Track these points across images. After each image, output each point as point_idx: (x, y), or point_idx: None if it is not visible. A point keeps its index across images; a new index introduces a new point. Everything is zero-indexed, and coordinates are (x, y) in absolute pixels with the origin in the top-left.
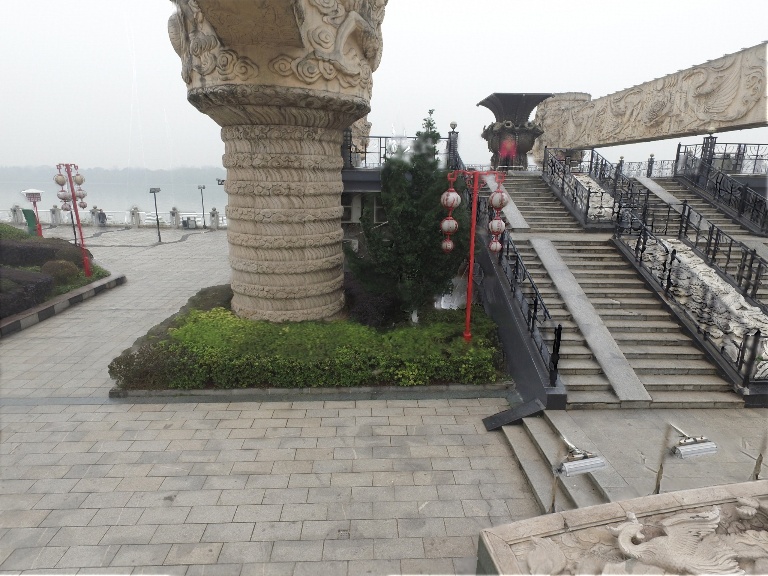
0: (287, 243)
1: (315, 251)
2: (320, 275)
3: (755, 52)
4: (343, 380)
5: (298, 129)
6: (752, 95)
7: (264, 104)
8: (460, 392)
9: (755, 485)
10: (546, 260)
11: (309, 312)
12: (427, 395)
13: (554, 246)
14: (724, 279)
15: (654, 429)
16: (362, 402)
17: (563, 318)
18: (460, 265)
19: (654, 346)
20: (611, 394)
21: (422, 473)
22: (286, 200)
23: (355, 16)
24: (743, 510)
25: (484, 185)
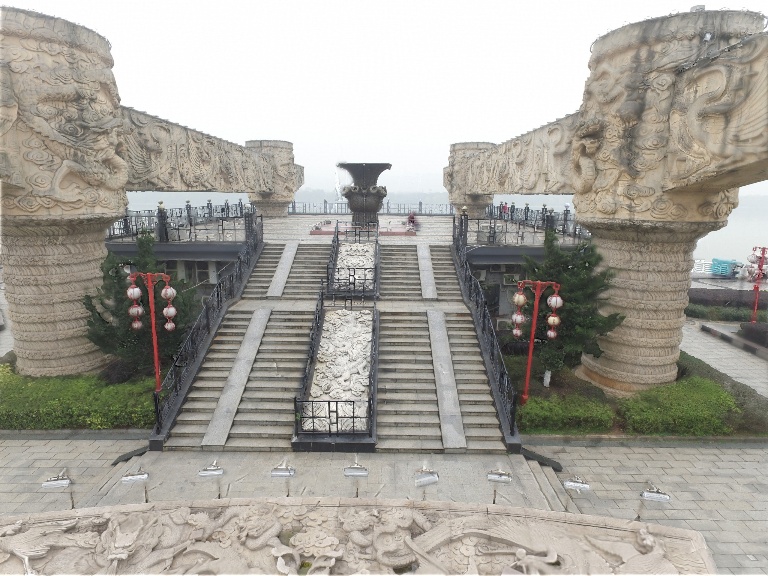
0: (39, 319)
1: (67, 324)
2: (74, 341)
3: (539, 134)
4: (48, 425)
5: (39, 239)
6: (537, 170)
7: (4, 225)
8: (134, 434)
9: (136, 506)
10: (251, 329)
11: (64, 369)
12: (107, 436)
13: (270, 316)
14: (371, 347)
15: (199, 467)
16: (54, 441)
17: (224, 379)
18: (188, 332)
19: (271, 402)
20: (201, 440)
21: (26, 494)
22: (36, 288)
23: (66, 164)
24: (96, 520)
25: (281, 253)
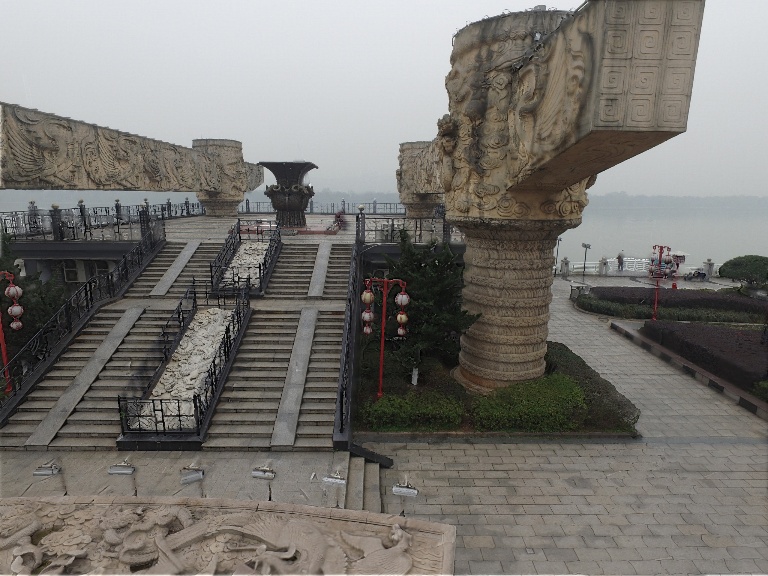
0: None
1: None
2: None
3: None
4: None
5: None
6: None
7: None
8: None
9: None
10: (116, 328)
11: None
12: None
13: (141, 315)
14: None
15: None
16: None
17: (73, 378)
18: None
19: (113, 402)
20: None
21: None
22: None
23: None
24: None
25: None
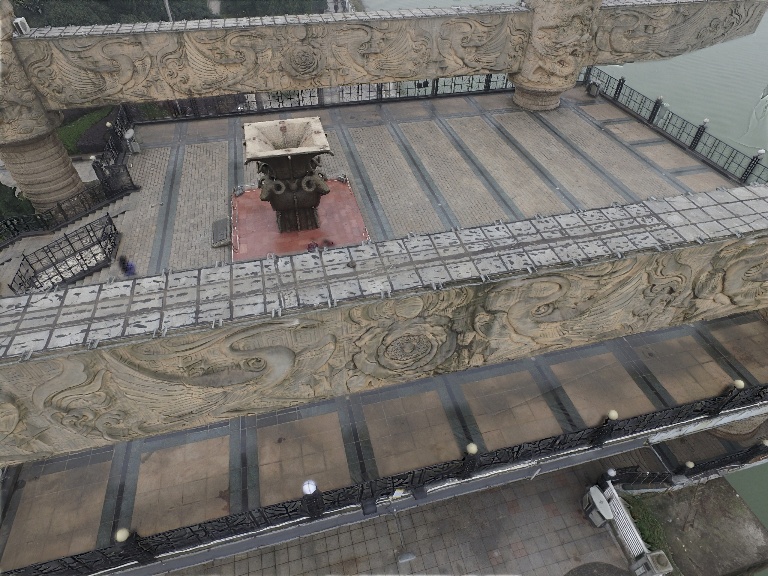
0: None
1: None
2: None
3: None
4: None
5: None
6: None
7: None
8: None
9: None
10: None
11: None
12: None
13: (5, 262)
14: None
15: None
16: None
17: None
18: None
19: None
20: None
21: None
22: None
23: None
24: None
25: None
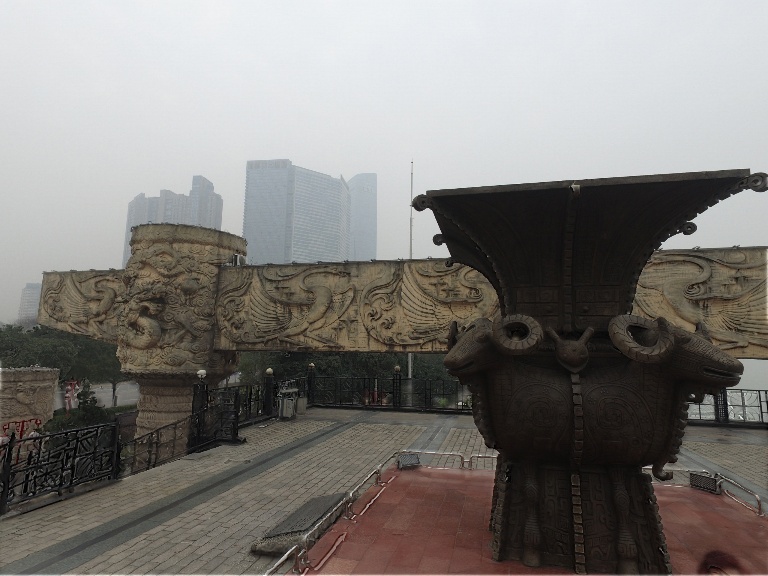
0: None
1: None
2: None
3: None
4: None
5: None
6: None
7: None
8: None
9: None
10: None
11: None
12: None
13: None
14: None
15: None
16: None
17: None
18: None
19: None
20: None
21: None
22: None
23: None
24: None
25: None
